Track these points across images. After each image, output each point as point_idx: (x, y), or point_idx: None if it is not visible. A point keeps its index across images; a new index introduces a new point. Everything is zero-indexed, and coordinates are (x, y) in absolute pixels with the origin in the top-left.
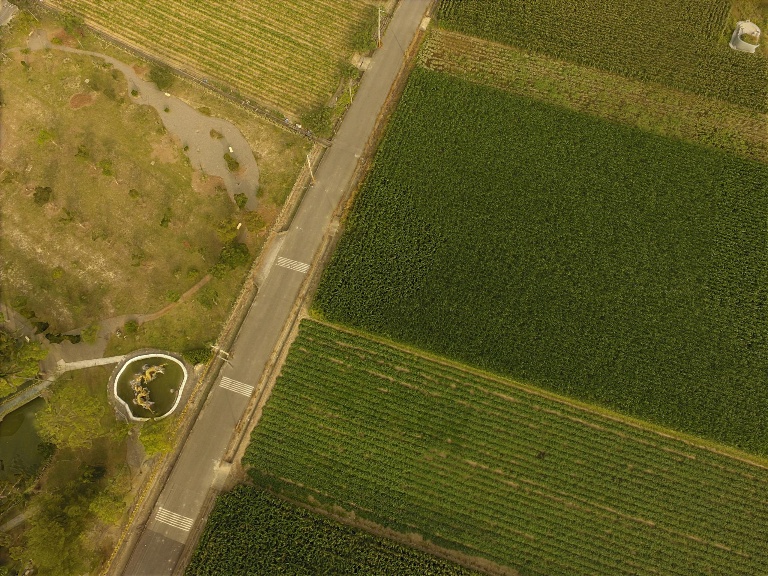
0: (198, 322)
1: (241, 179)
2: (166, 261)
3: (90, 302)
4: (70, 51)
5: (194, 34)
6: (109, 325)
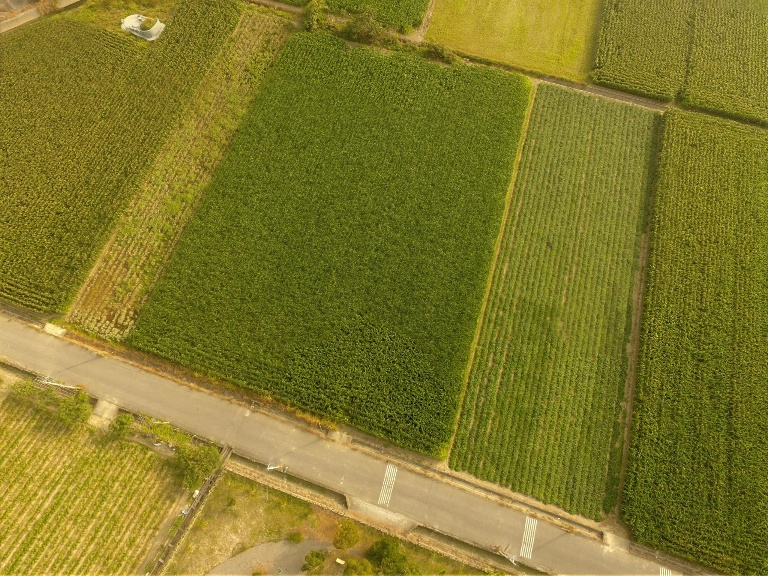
0: None
1: (272, 569)
2: None
3: None
4: None
5: None
6: None
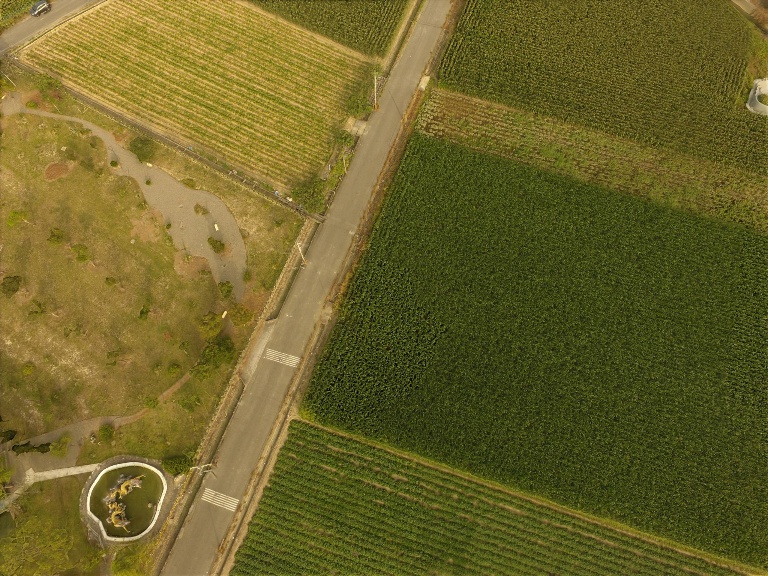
0: (179, 425)
1: (227, 260)
2: (145, 354)
3: (63, 402)
4: (46, 116)
5: (179, 95)
6: (83, 428)
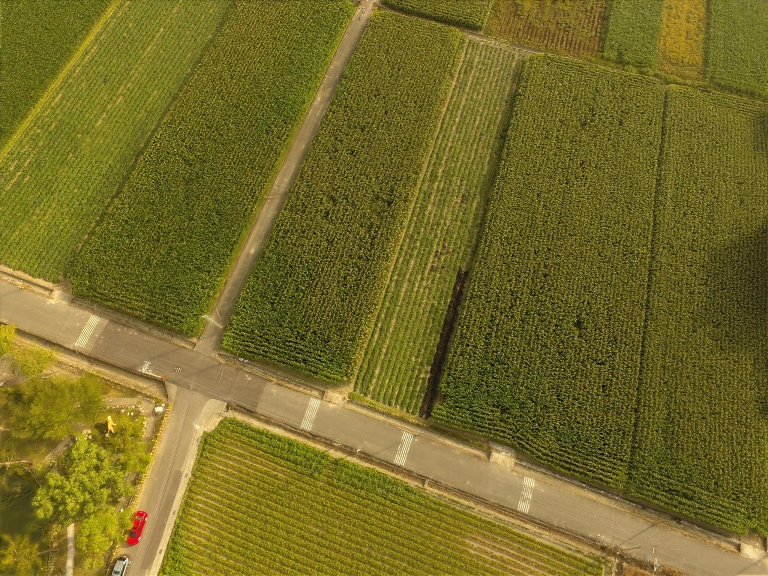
0: None
1: None
2: None
3: None
4: None
5: None
6: None
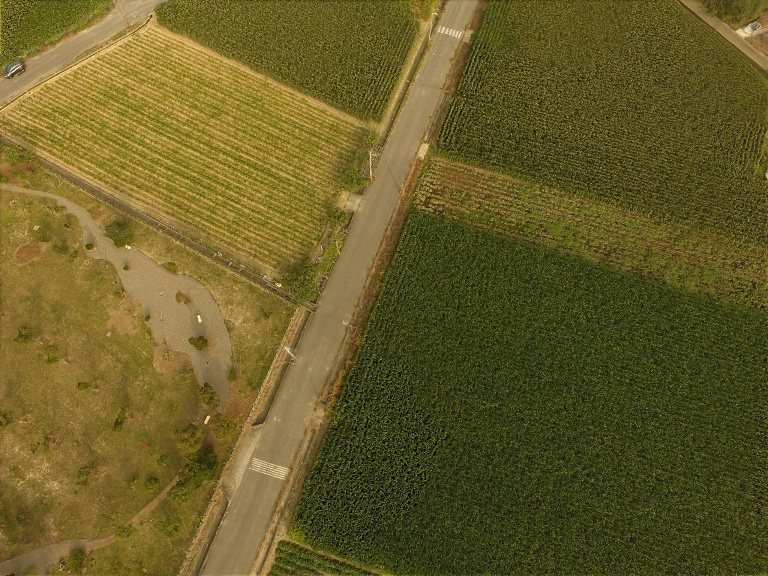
0: (156, 549)
1: (211, 356)
2: (121, 466)
3: (29, 522)
4: (17, 191)
5: (160, 167)
6: (51, 553)
